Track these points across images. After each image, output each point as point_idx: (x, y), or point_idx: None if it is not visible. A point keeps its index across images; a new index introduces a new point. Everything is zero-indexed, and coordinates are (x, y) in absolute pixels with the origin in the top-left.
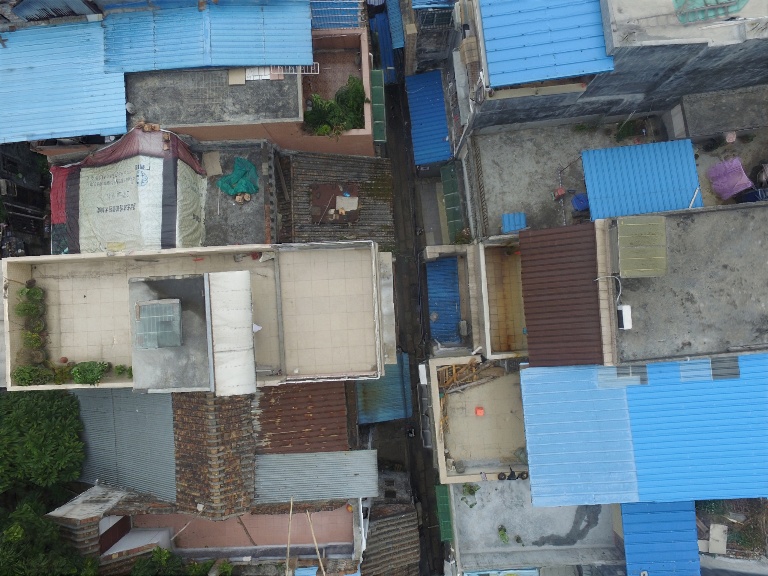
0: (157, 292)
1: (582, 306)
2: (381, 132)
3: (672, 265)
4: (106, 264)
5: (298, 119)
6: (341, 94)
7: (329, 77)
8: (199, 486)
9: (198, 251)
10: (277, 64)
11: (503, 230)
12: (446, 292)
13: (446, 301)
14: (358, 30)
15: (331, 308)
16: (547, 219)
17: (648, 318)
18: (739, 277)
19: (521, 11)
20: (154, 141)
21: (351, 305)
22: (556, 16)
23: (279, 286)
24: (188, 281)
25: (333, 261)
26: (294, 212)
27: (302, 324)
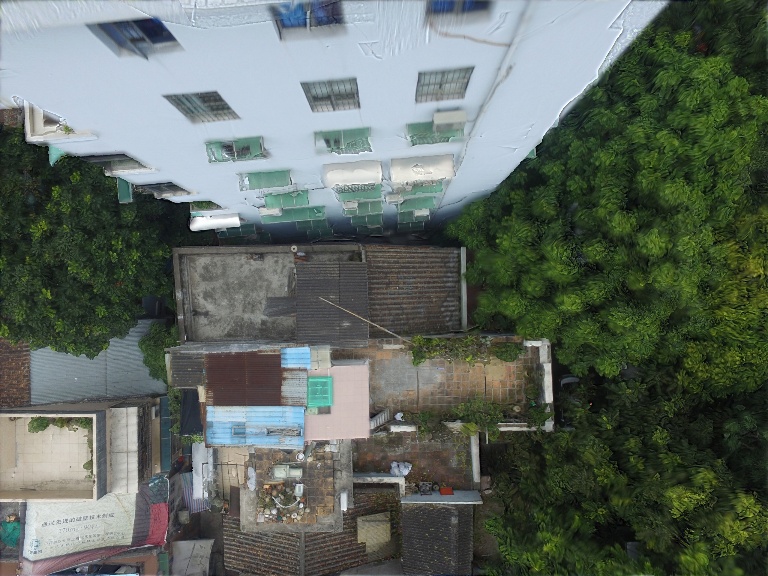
0: None
1: None
2: None
3: None
4: (55, 488)
5: None
6: None
7: None
8: (1, 341)
9: None
10: None
11: None
12: None
13: None
14: None
15: None
16: None
17: None
18: None
19: None
20: (26, 570)
21: None
22: None
23: None
24: None
25: None
26: None
27: None
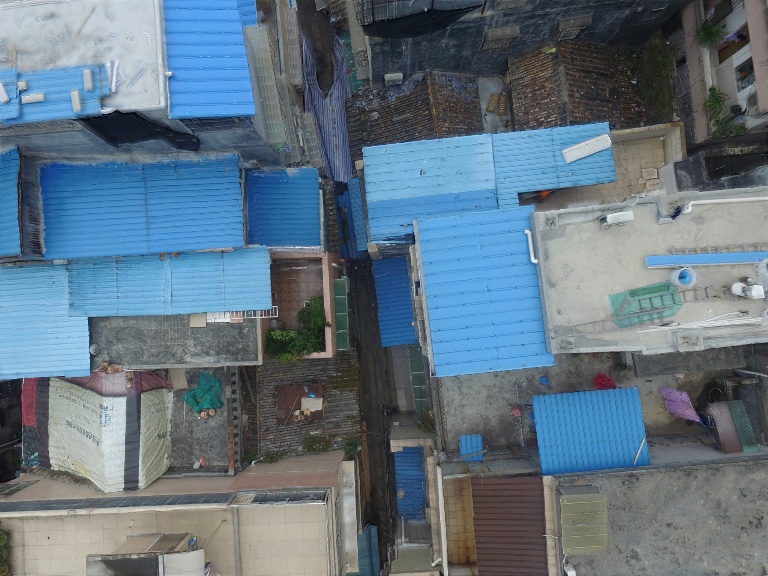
0: (113, 570)
1: (531, 558)
2: (344, 341)
3: (617, 523)
4: None
5: (257, 363)
6: (303, 316)
7: (293, 287)
8: None
9: (157, 510)
10: (237, 310)
11: (460, 452)
12: (413, 470)
13: (413, 479)
14: (319, 254)
15: (288, 552)
16: (505, 432)
17: (594, 575)
18: (682, 536)
19: (465, 304)
20: (117, 380)
21: (308, 548)
22: (499, 310)
23: (238, 531)
24: (144, 560)
25: (290, 505)
26: (260, 415)
27: (260, 567)
